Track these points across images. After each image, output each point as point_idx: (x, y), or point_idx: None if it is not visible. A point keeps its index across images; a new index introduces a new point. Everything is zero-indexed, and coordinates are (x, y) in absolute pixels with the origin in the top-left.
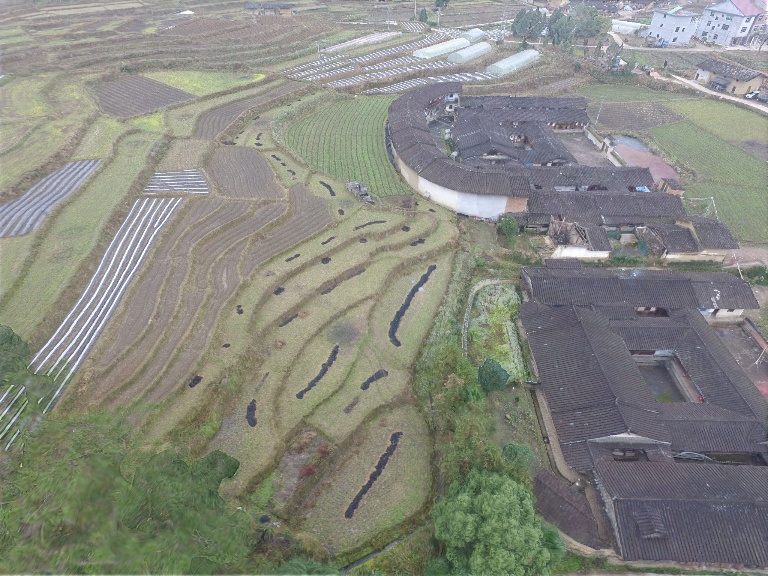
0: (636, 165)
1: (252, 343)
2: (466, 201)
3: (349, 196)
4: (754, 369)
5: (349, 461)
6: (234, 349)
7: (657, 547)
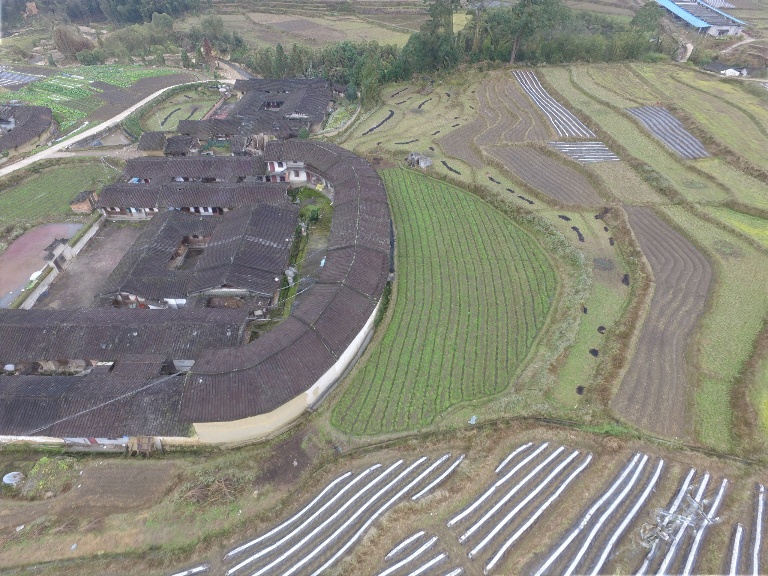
0: None
1: None
2: None
3: None
4: None
5: None
6: (464, 98)
7: None
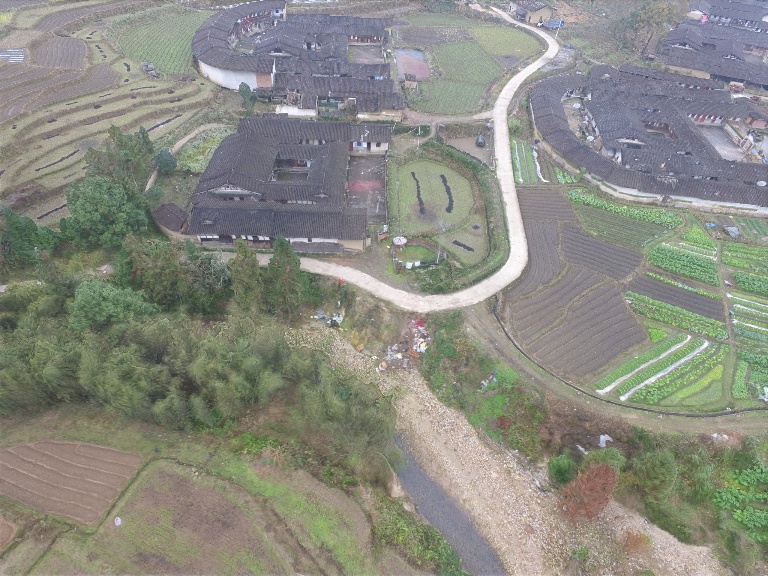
0: (404, 68)
1: (14, 143)
2: (228, 77)
3: (140, 72)
4: (369, 176)
5: (55, 199)
6: None
7: (208, 228)
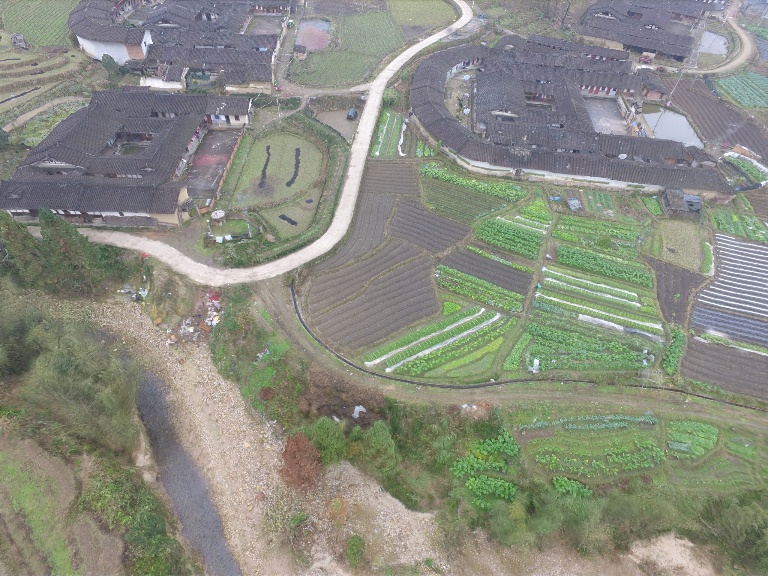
0: (302, 39)
1: None
2: (99, 49)
3: (9, 44)
4: None
5: None
6: None
7: (13, 202)
